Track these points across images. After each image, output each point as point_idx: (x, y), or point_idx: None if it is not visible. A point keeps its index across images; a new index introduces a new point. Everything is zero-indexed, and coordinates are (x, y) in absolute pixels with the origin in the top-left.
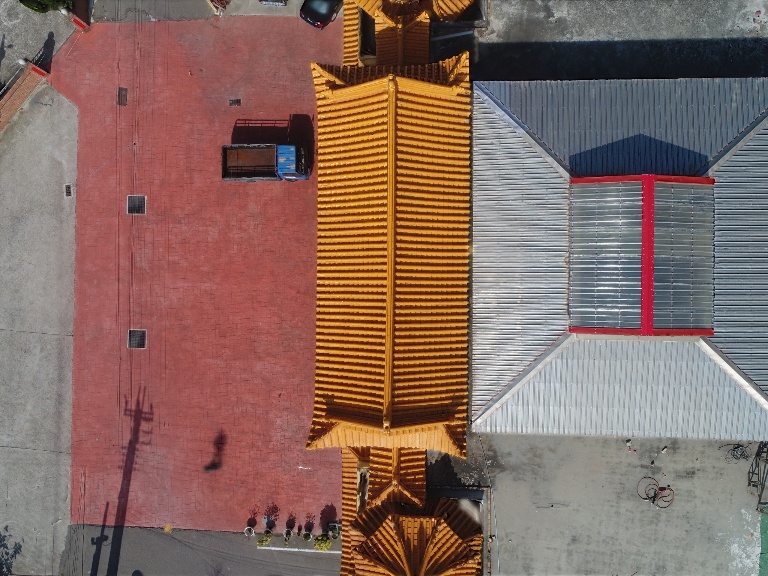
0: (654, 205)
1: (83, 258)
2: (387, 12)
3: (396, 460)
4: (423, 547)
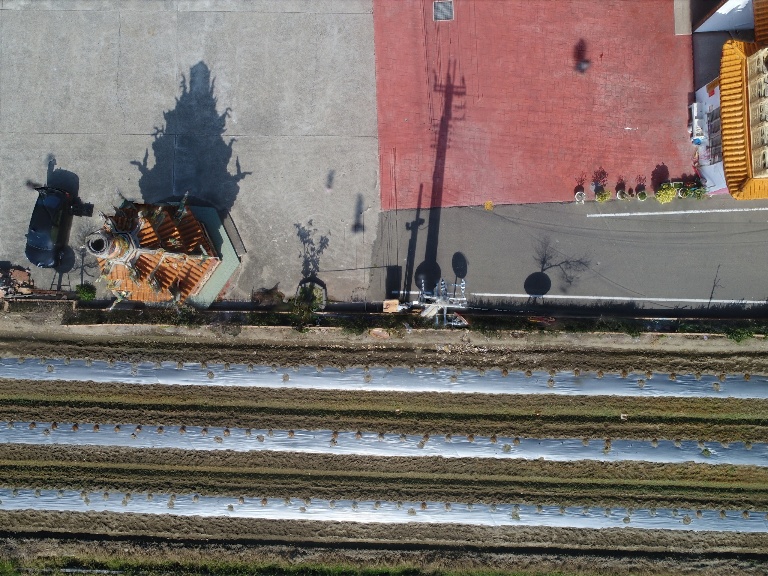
0: None
1: None
2: None
3: None
4: None
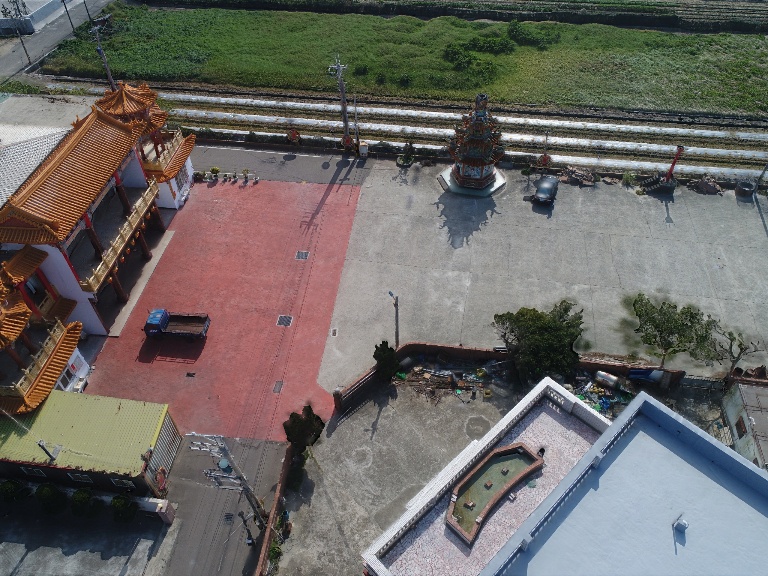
0: None
1: (331, 296)
2: (13, 300)
3: None
4: (116, 104)
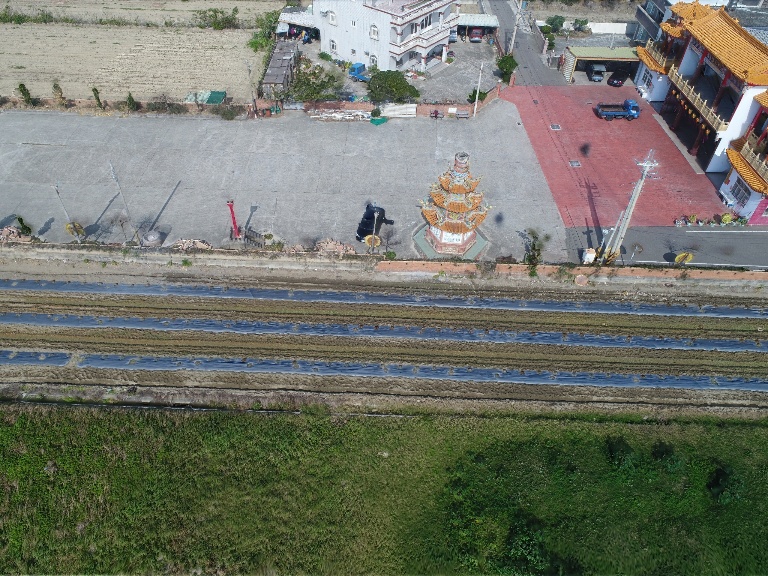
0: None
1: (534, 141)
2: None
3: None
4: None
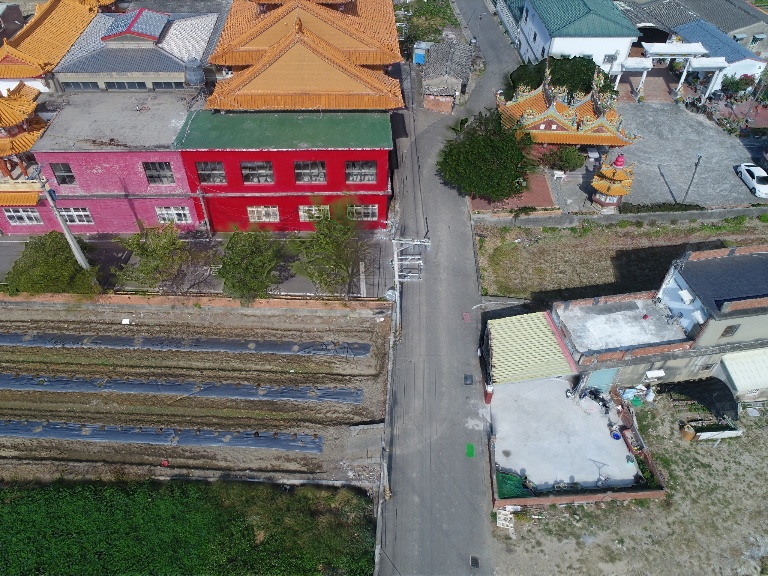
0: (142, 13)
1: None
2: None
3: (14, 89)
4: None
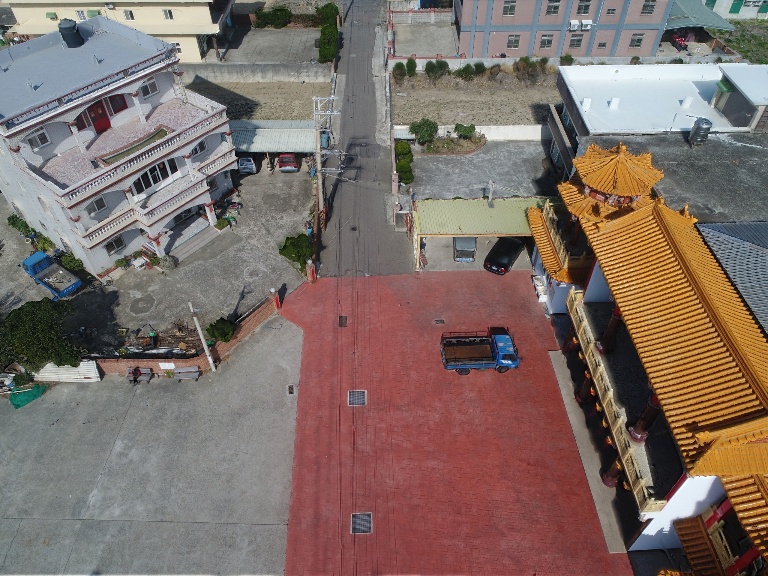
0: None
1: (303, 446)
2: None
3: None
4: None
